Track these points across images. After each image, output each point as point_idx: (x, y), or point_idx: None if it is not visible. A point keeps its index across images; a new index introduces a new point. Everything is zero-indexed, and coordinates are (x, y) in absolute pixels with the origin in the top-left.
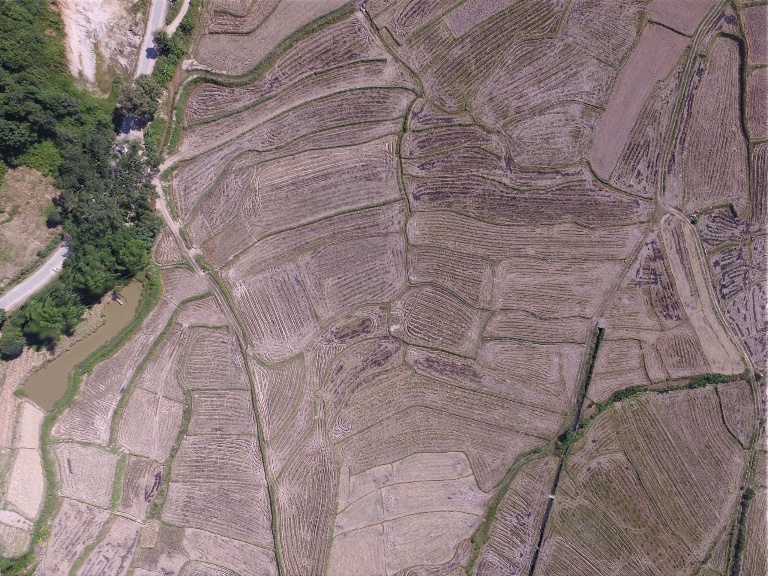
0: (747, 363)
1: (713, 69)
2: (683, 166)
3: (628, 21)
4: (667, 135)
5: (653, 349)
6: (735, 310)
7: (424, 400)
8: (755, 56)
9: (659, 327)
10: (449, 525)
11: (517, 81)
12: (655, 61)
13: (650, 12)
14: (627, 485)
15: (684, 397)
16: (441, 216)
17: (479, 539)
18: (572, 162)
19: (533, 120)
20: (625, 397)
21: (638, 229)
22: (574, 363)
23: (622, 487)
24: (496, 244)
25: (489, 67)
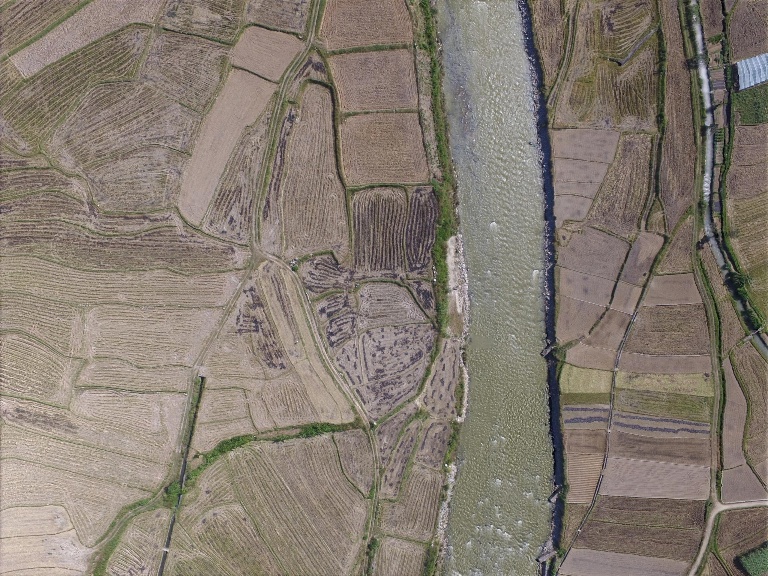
0: (359, 412)
1: (306, 115)
2: (279, 213)
3: (210, 66)
4: (259, 181)
5: (258, 398)
6: (345, 358)
7: (16, 452)
8: (347, 103)
9: (263, 376)
10: None
11: (95, 124)
12: (242, 106)
13: (233, 57)
14: (245, 537)
15: (300, 446)
16: (23, 261)
17: None
18: (160, 207)
19: (116, 164)
20: (239, 446)
21: (235, 276)
22: (176, 413)
23: (240, 539)
24: (84, 290)
25: (63, 109)
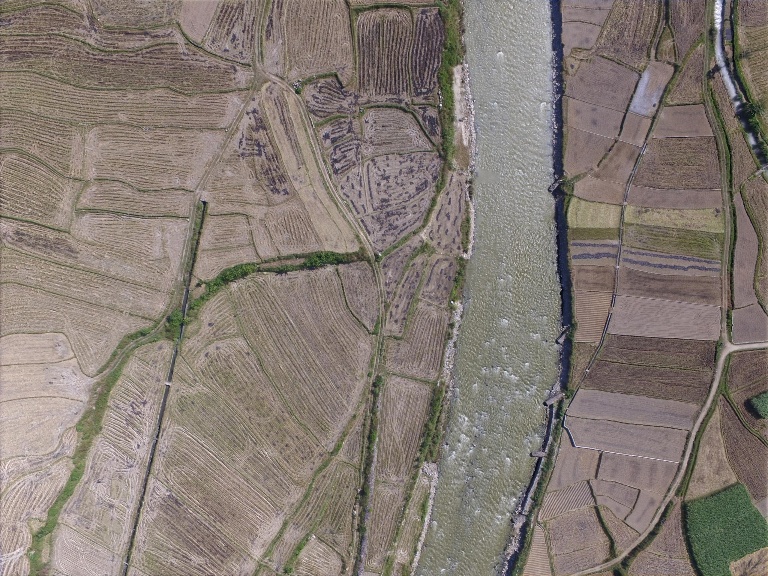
0: (363, 242)
1: None
2: (282, 32)
3: None
4: None
5: (262, 225)
6: (349, 186)
7: (16, 276)
8: None
9: (266, 201)
10: (52, 412)
11: None
12: None
13: None
14: (249, 372)
15: (304, 279)
16: (23, 77)
17: (88, 428)
18: (161, 23)
19: None
20: (242, 278)
21: (238, 97)
22: (178, 239)
23: (243, 374)
24: (85, 109)
25: None
